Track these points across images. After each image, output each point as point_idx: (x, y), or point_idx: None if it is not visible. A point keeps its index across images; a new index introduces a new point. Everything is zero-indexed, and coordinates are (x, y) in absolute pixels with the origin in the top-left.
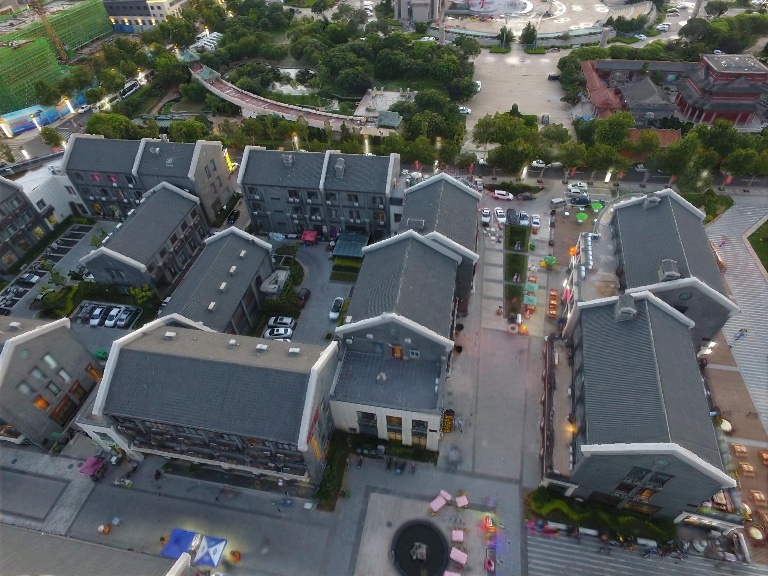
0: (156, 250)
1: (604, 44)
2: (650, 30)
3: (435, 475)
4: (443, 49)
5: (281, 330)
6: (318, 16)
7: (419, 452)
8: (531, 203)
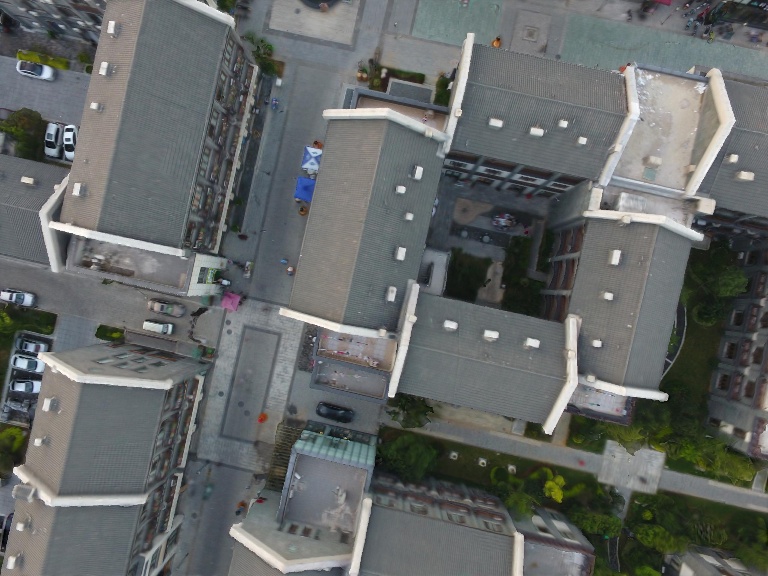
0: None
1: None
2: None
3: None
4: None
5: (67, 135)
6: None
7: None
8: None
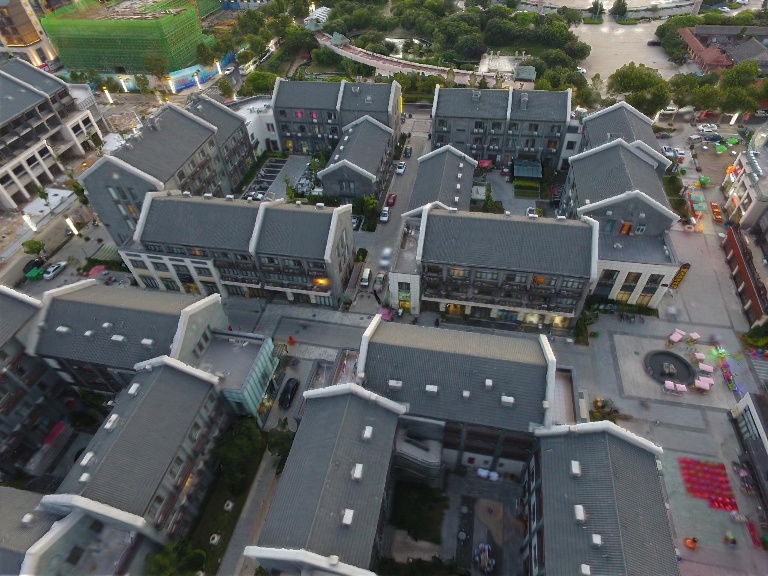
0: (377, 167)
1: (695, 14)
2: (731, 3)
3: (661, 324)
4: (551, 17)
5: None
6: None
7: (644, 308)
8: (669, 140)
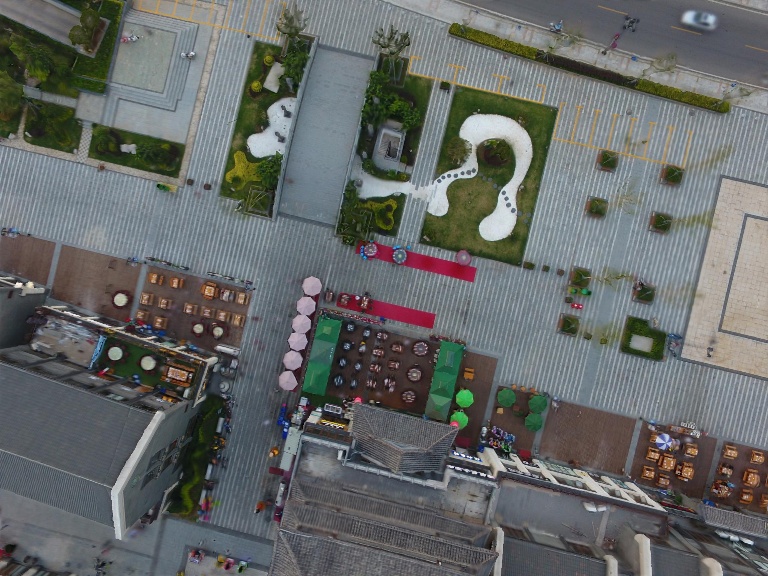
0: None
1: None
2: None
3: None
4: None
5: None
6: None
7: None
8: None
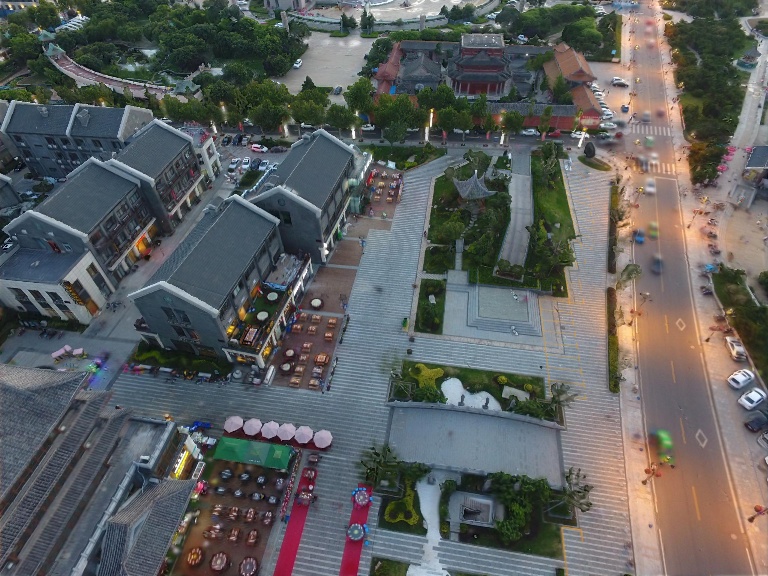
0: None
1: (423, 29)
2: (480, 18)
3: (76, 339)
4: (270, 31)
5: None
6: (189, 3)
7: (71, 324)
8: (281, 155)
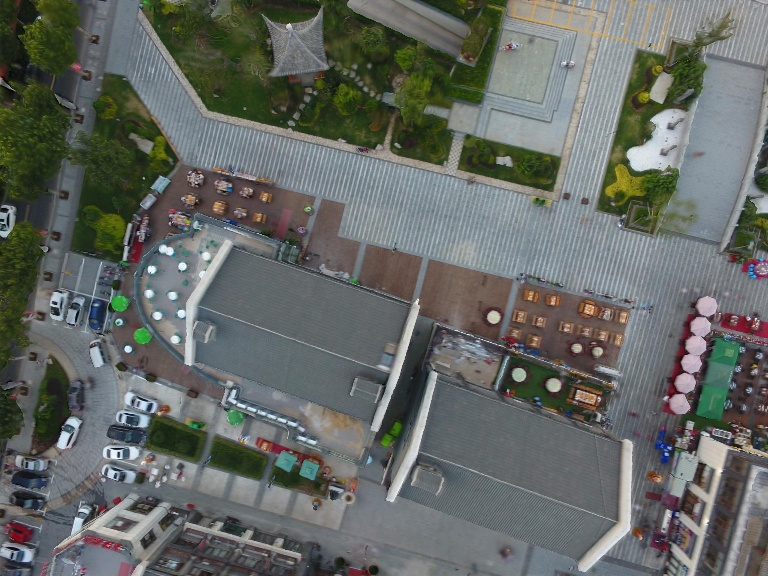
0: None
1: None
2: None
3: None
4: None
5: None
6: None
7: None
8: (92, 391)
